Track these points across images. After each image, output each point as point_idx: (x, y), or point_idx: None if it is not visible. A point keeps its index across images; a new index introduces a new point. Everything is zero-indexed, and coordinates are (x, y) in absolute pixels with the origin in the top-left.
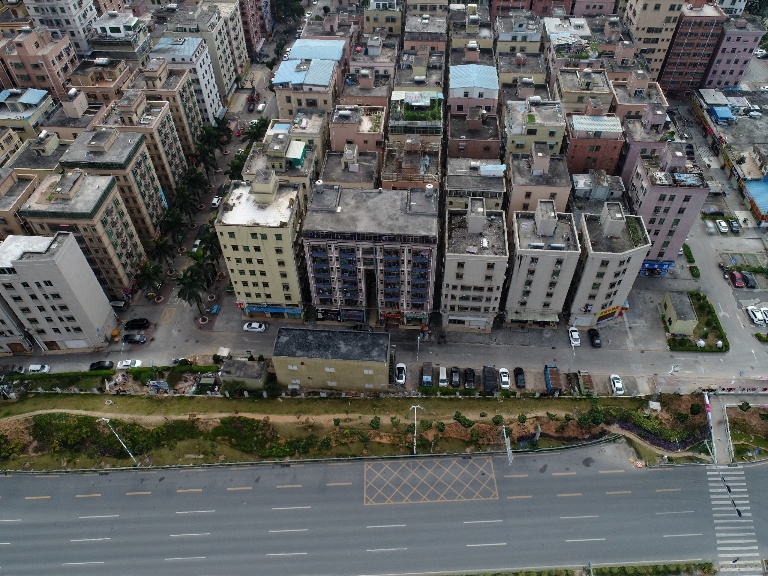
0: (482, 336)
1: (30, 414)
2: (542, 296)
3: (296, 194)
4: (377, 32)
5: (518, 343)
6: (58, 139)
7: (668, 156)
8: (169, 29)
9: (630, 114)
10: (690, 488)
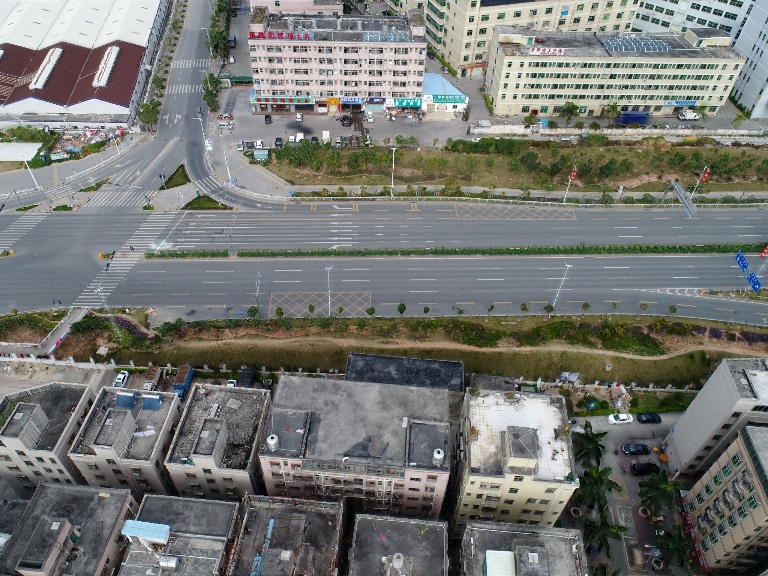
0: None
1: (671, 355)
2: None
3: None
4: None
5: None
6: None
7: None
8: None
9: None
10: (124, 295)
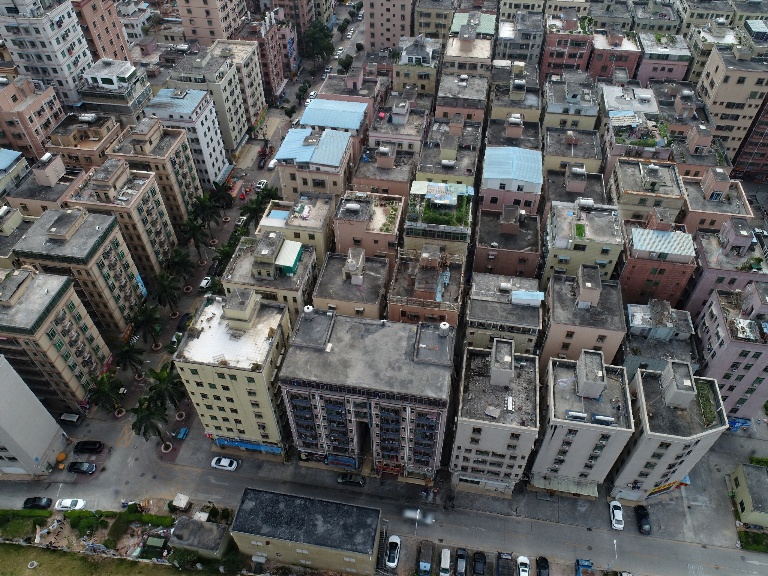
0: (500, 502)
1: None
2: (579, 466)
3: (279, 321)
4: (406, 91)
5: (544, 517)
6: (21, 215)
7: (755, 300)
8: (173, 77)
9: (703, 222)
10: None
